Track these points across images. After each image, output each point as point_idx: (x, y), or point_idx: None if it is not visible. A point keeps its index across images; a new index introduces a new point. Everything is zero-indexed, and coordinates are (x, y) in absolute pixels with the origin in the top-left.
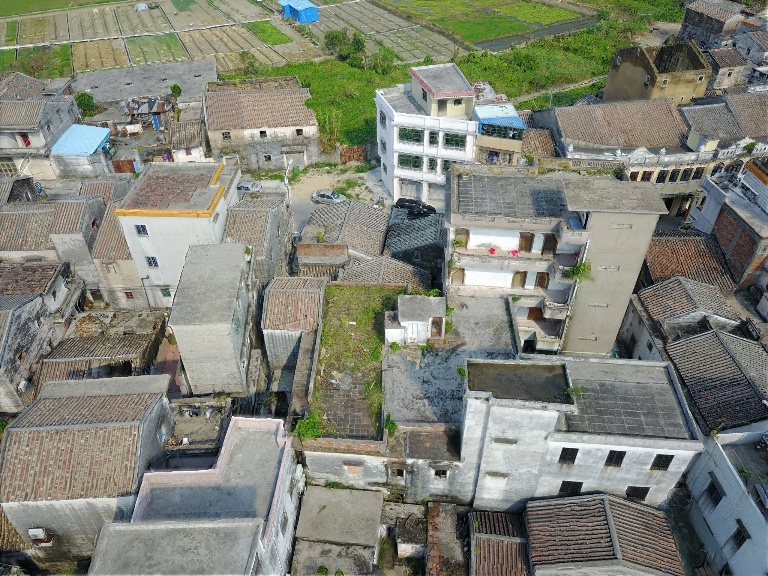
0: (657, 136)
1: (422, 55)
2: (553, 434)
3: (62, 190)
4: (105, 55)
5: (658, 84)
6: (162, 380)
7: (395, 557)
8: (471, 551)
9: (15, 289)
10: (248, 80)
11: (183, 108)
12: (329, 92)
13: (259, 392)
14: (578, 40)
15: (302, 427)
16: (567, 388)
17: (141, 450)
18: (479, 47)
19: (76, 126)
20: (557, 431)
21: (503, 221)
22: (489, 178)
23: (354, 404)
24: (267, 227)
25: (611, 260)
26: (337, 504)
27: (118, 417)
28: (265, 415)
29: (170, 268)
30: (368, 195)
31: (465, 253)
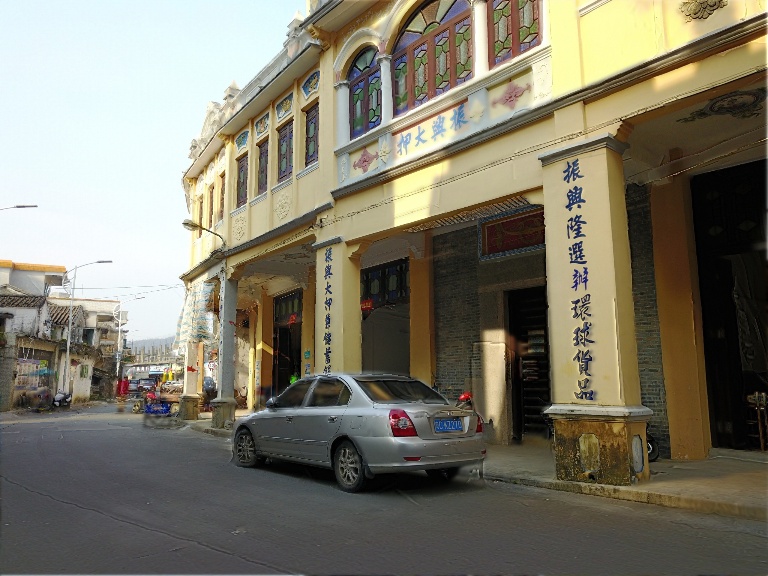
0: None
1: None
2: None
3: None
4: None
5: None
6: None
7: None
8: None
9: None
10: None
11: None
12: None
13: None
14: None
15: None
16: None
17: None
18: None
19: None
20: None
21: None
22: None
23: None
24: None
25: None
26: None
27: None
28: None
29: None
30: None
31: None
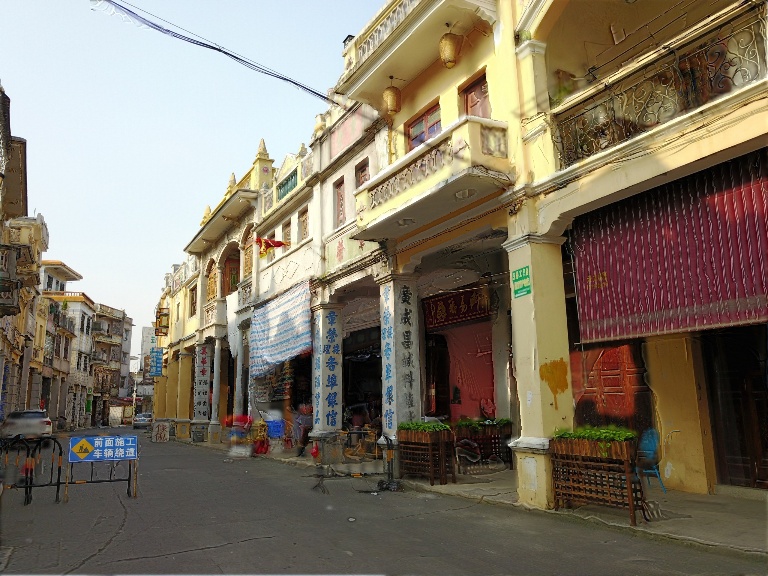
0: None
1: None
2: None
3: None
4: None
5: None
6: None
7: None
8: None
9: None
10: None
11: None
12: None
13: None
14: None
15: None
16: None
17: None
18: None
19: None
20: None
21: None
22: None
23: None
24: None
25: None
26: None
27: None
28: None
29: None
30: None
31: None
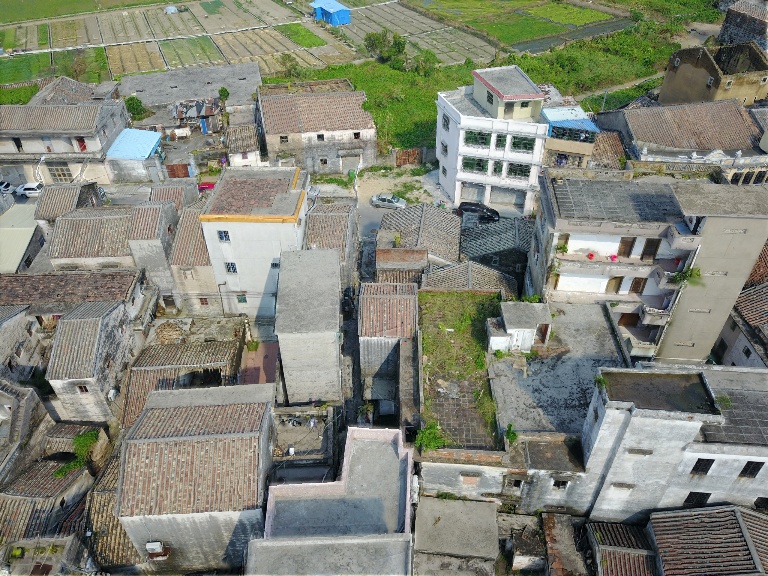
0: (728, 138)
1: (459, 57)
2: (692, 445)
3: (117, 195)
4: (141, 58)
5: (722, 85)
6: (268, 389)
7: (509, 569)
8: (597, 564)
9: (96, 296)
10: (299, 83)
11: (231, 111)
12: (374, 95)
13: (346, 400)
14: (616, 41)
15: (424, 438)
16: (709, 398)
17: (261, 462)
18: (516, 49)
19: (128, 130)
20: (694, 442)
21: (610, 226)
22: (583, 182)
23: (466, 413)
24: (347, 232)
25: (720, 265)
26: (452, 515)
27: (234, 428)
28: (363, 424)
29: (249, 274)
30: (427, 199)
31: (562, 258)
